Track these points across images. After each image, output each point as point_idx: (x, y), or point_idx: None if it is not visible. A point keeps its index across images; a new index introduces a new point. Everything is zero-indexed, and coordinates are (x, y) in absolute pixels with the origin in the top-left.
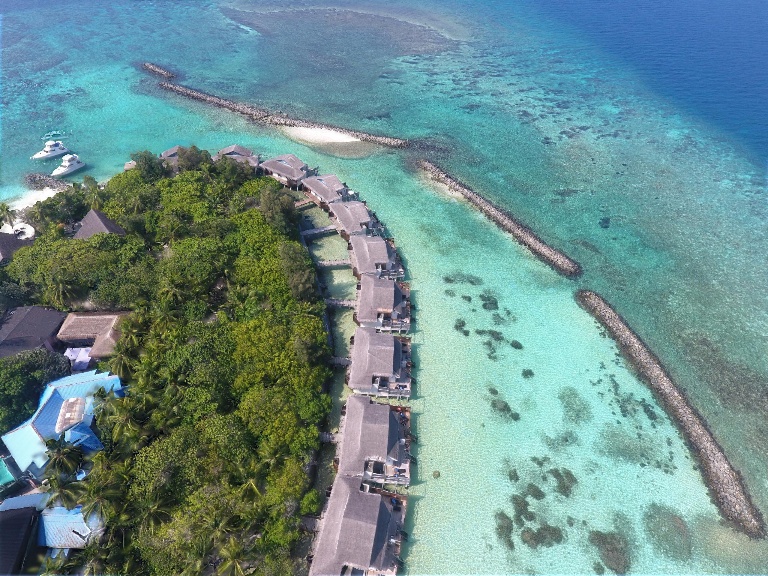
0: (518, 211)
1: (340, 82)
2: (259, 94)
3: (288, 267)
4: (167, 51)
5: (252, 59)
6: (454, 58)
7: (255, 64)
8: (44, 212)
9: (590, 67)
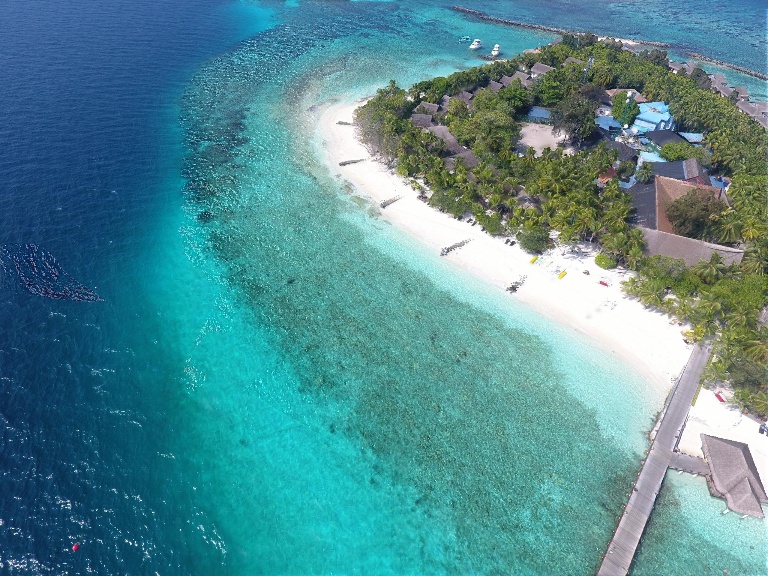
0: (765, 74)
1: (588, 17)
2: (546, 22)
3: (695, 75)
4: (453, 1)
5: (514, 5)
6: (648, 4)
7: (520, 7)
8: (542, 59)
9: (749, 9)
